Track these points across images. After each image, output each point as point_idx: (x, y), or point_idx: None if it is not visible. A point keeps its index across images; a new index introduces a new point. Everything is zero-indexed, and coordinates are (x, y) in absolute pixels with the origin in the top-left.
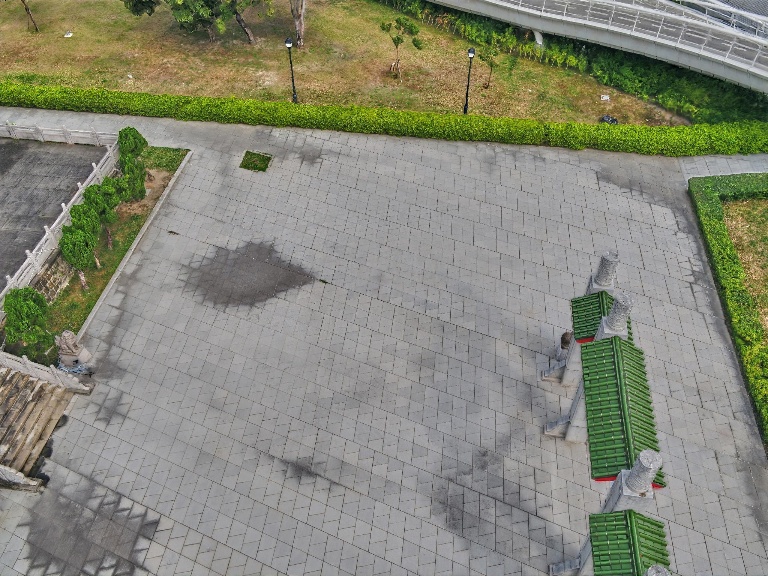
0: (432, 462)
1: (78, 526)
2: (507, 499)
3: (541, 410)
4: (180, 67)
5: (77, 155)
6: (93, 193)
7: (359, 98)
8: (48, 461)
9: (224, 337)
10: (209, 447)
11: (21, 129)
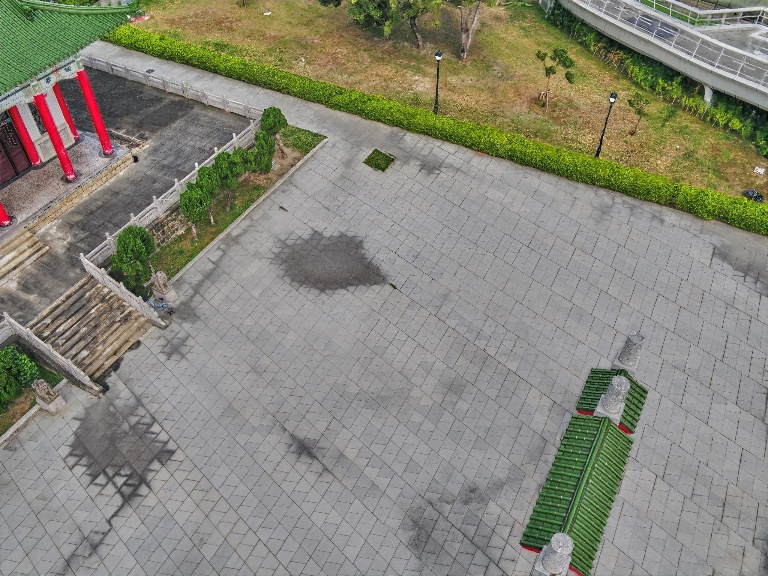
0: (421, 481)
1: (115, 434)
2: (476, 540)
3: (547, 468)
4: (348, 59)
5: (228, 122)
6: (221, 159)
7: (500, 119)
8: (113, 374)
9: (288, 312)
10: (238, 403)
11: (192, 91)
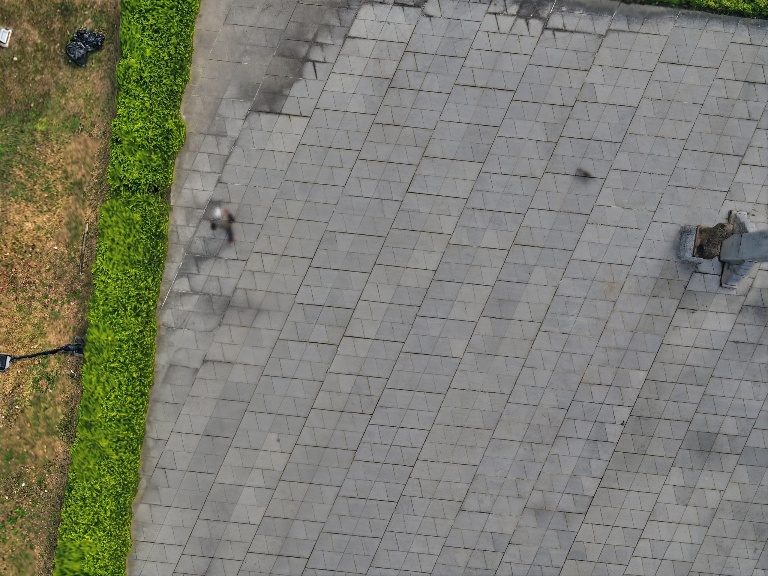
0: None
1: None
2: None
3: None
4: None
5: None
6: None
7: None
8: None
9: None
10: None
11: None
